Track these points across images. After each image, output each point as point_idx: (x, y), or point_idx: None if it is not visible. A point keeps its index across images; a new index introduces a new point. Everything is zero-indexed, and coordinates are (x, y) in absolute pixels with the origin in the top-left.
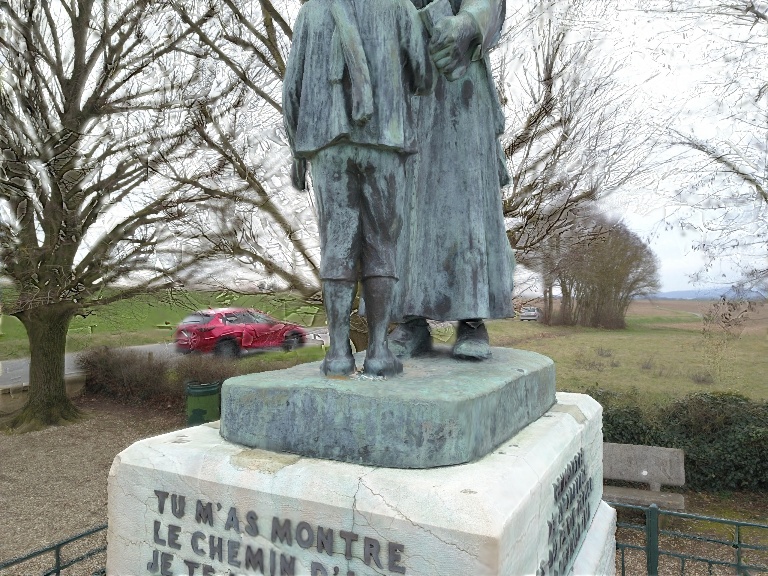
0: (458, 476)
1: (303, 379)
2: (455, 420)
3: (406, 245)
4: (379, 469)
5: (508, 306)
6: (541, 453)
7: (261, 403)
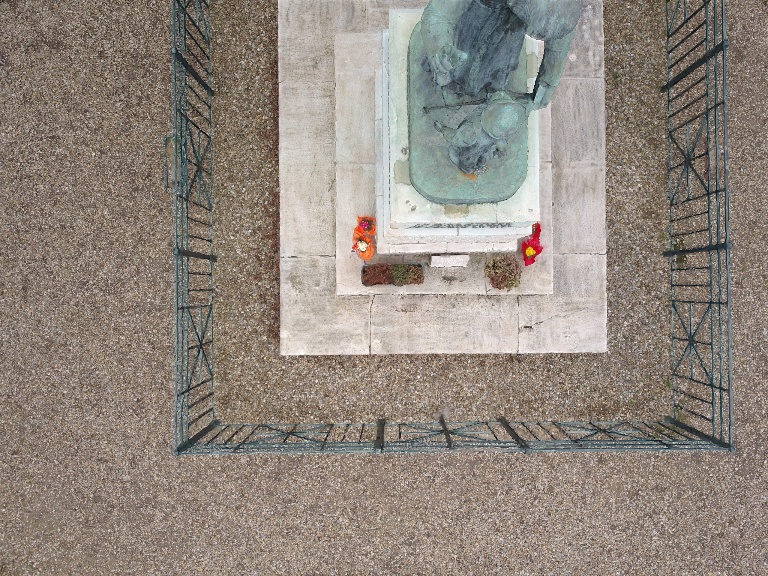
0: (523, 198)
1: (464, 191)
2: (521, 185)
3: (467, 67)
4: (498, 205)
5: (517, 65)
6: (536, 149)
7: (450, 200)
